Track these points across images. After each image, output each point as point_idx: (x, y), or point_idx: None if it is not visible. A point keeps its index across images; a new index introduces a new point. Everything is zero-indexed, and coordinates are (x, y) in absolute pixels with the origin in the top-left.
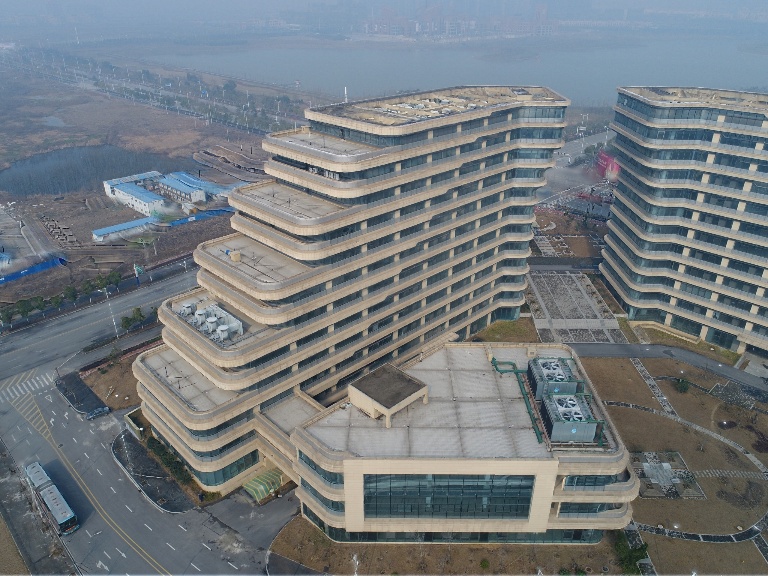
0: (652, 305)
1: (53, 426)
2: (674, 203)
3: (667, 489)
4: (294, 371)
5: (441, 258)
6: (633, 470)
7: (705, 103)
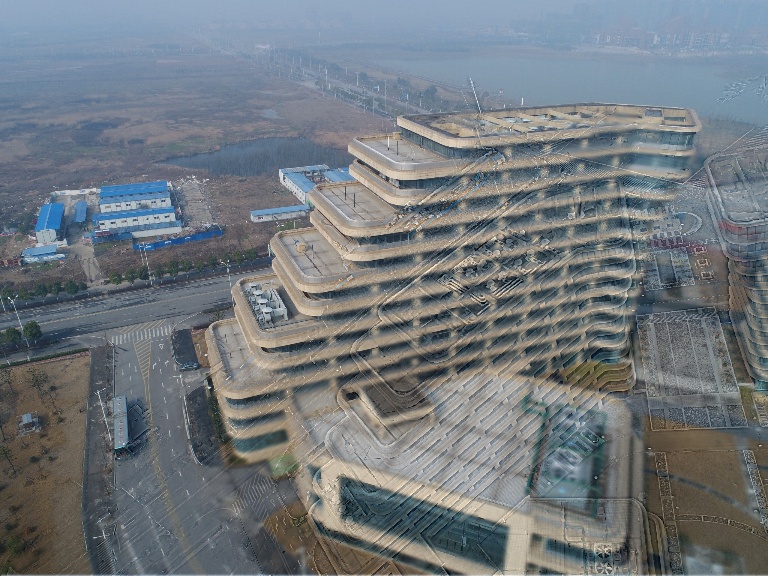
0: None
1: (278, 532)
2: None
3: None
4: (411, 528)
5: (525, 399)
6: None
7: None
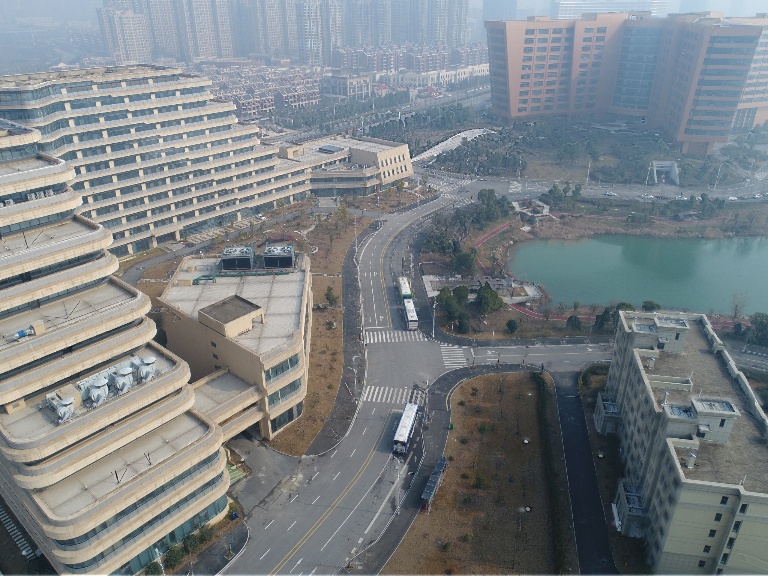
0: None
1: None
2: None
3: None
4: None
5: None
6: None
7: (49, 81)
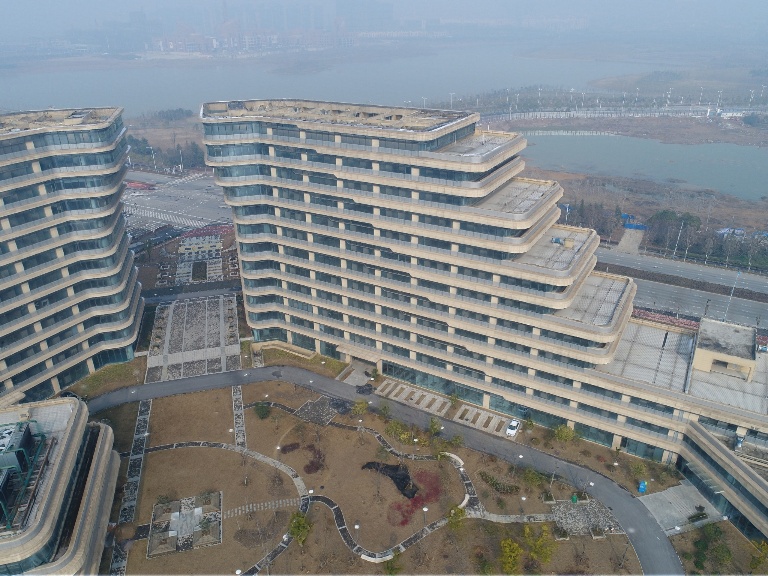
0: (271, 324)
1: None
2: (256, 220)
3: (184, 540)
4: None
5: None
6: (81, 542)
7: (251, 117)
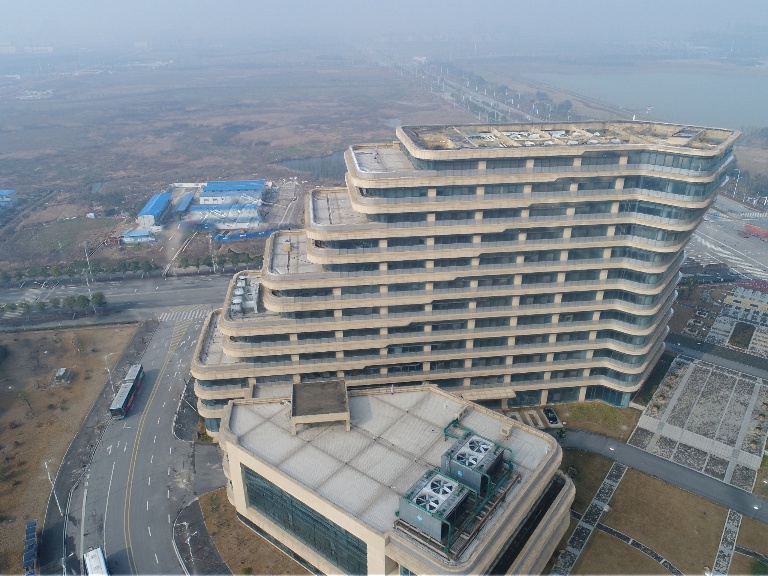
0: None
1: (180, 346)
2: None
3: None
4: (294, 361)
5: (498, 303)
6: None
7: None
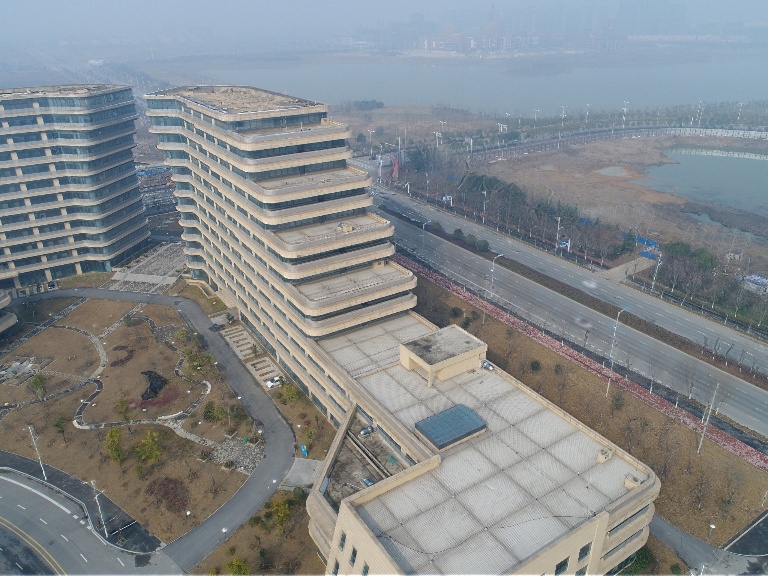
0: (198, 266)
1: None
2: (182, 179)
3: (5, 378)
4: None
5: None
6: None
7: (173, 96)
